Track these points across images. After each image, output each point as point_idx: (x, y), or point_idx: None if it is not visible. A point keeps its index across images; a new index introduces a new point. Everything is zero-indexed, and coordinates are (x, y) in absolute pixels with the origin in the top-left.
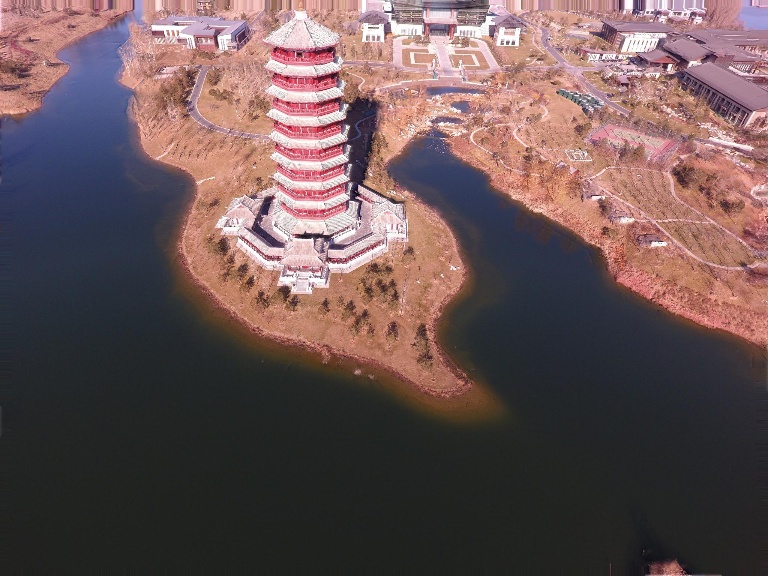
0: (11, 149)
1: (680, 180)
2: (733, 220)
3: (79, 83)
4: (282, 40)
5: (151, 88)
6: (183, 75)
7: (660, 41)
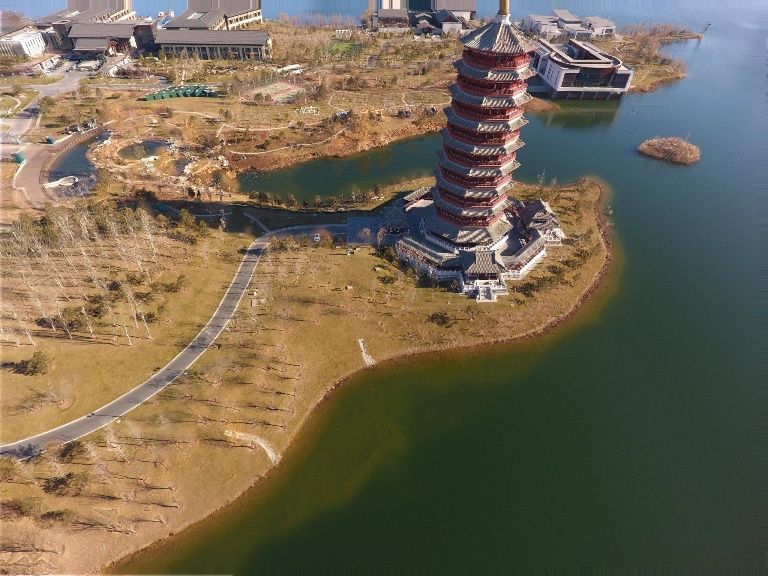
0: None
1: (349, 90)
2: (399, 88)
3: None
4: (529, 43)
5: None
6: None
7: (42, 35)
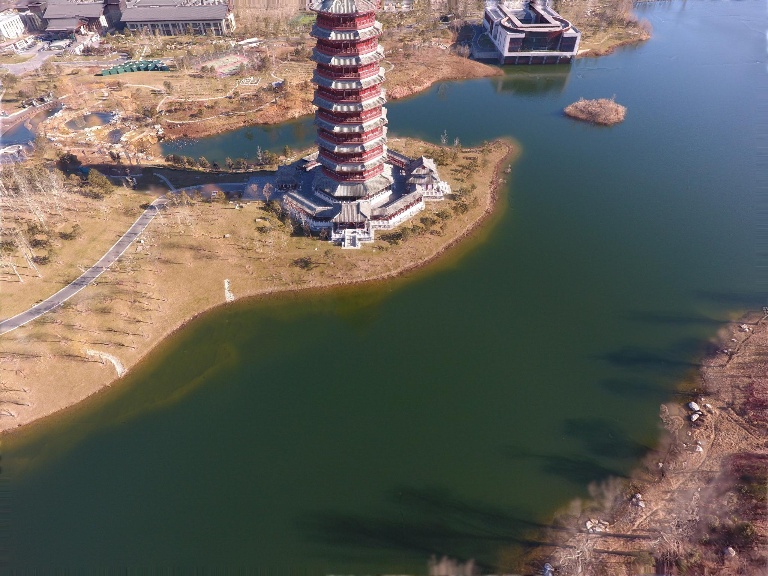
0: None
1: (296, 60)
2: None
3: None
4: (368, 4)
5: None
6: None
7: (21, 17)
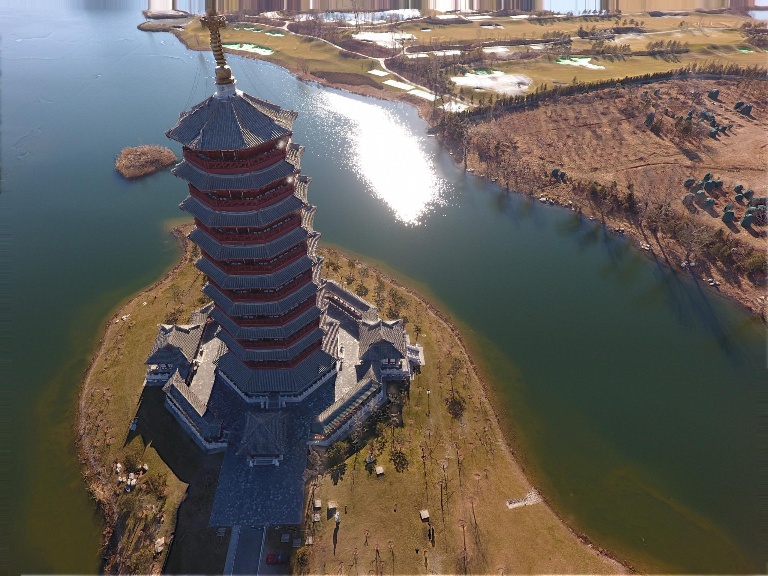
0: None
1: None
2: None
3: None
4: None
5: None
6: None
7: None
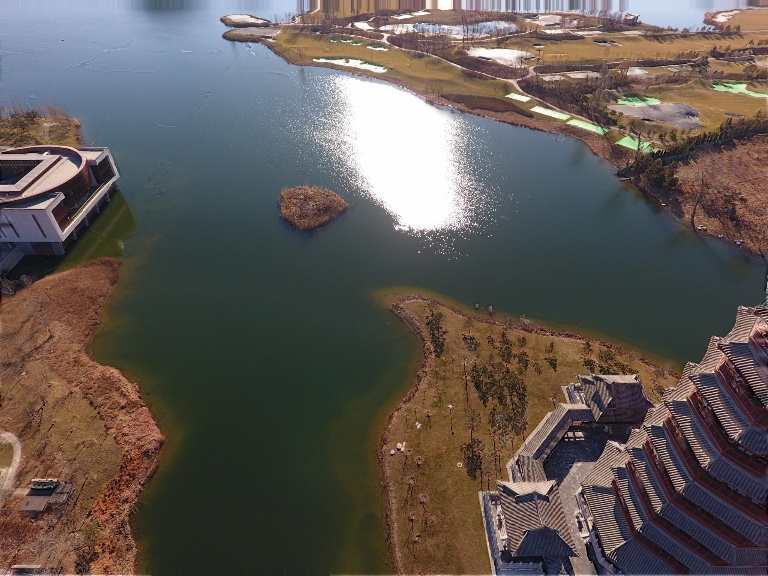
0: None
1: None
2: None
3: None
4: None
5: None
6: None
7: None
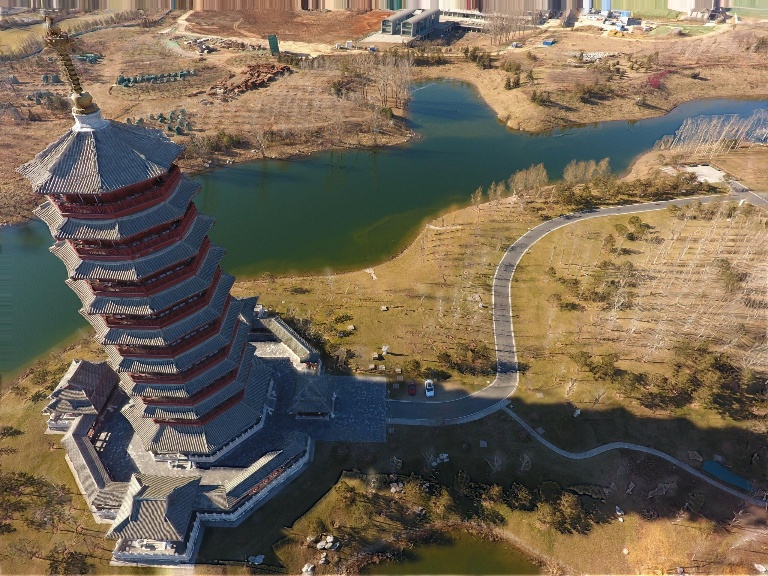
0: (434, 146)
1: None
2: None
3: (628, 133)
4: None
5: (636, 175)
6: (662, 181)
7: None
